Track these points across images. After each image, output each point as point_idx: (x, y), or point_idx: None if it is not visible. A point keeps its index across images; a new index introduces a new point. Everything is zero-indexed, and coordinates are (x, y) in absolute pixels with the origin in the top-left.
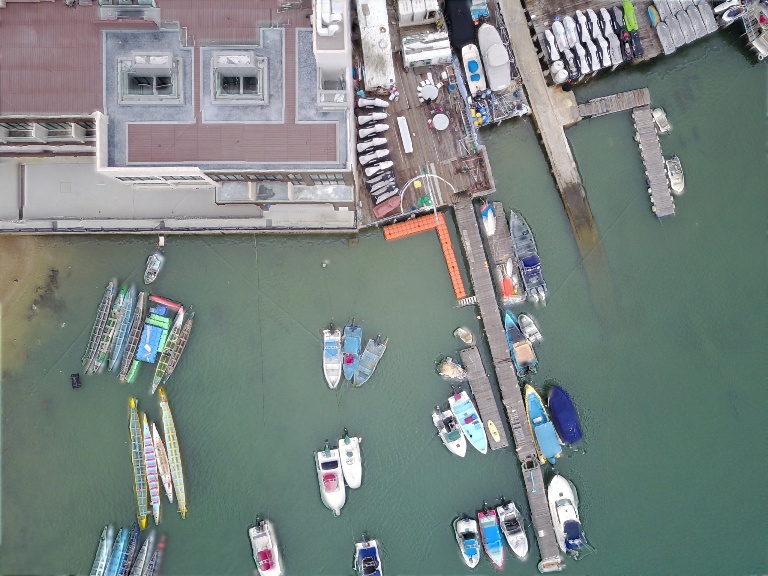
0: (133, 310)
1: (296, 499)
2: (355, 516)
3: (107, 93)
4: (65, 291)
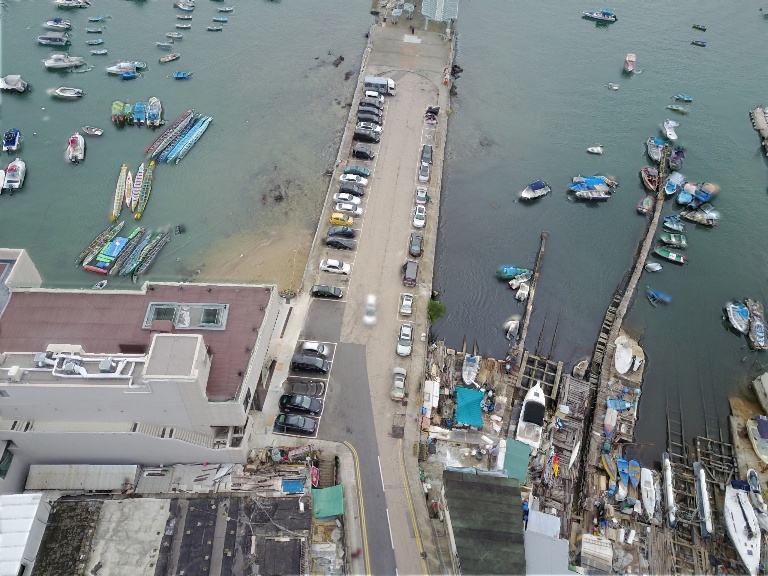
0: (121, 265)
1: (46, 169)
2: (11, 161)
3: (3, 307)
4: (174, 280)
